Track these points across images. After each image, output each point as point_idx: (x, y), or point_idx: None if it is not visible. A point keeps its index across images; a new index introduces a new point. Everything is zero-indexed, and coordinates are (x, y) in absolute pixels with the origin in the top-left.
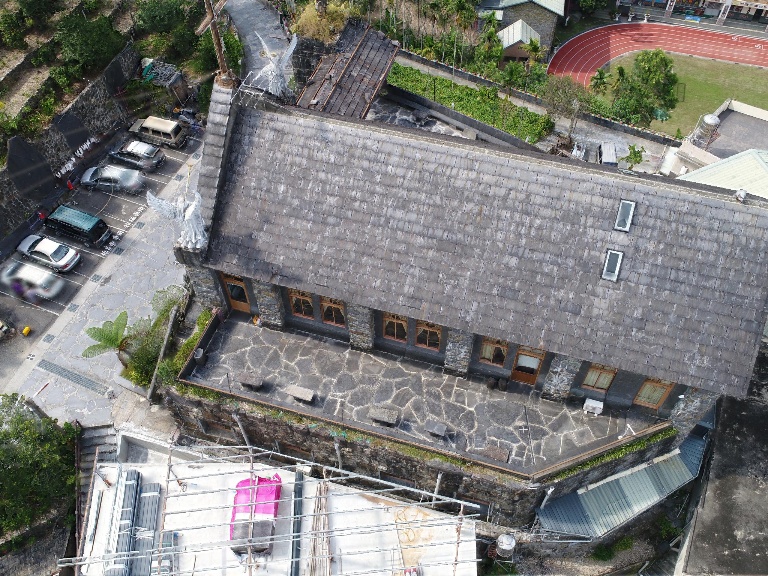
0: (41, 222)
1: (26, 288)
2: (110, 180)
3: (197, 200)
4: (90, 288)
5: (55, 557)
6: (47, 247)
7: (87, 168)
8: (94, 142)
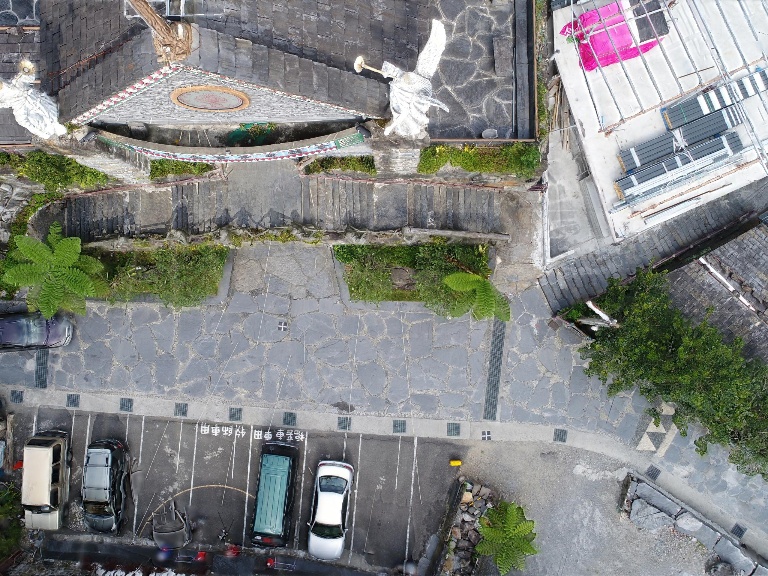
0: (279, 559)
1: (391, 509)
2: (164, 508)
3: (393, 67)
4: (363, 423)
5: (681, 279)
6: (331, 508)
7: (154, 555)
8: (103, 569)
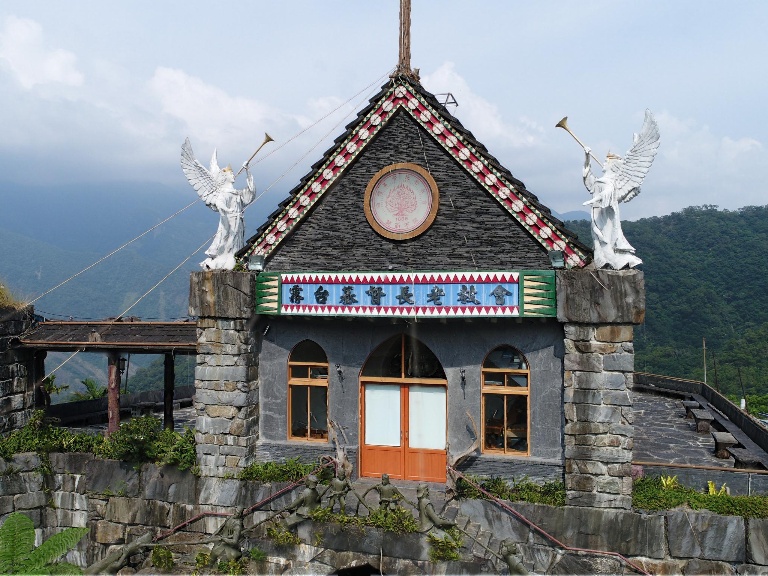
0: None
1: None
2: None
3: None
4: None
5: None
6: None
7: None
8: None
